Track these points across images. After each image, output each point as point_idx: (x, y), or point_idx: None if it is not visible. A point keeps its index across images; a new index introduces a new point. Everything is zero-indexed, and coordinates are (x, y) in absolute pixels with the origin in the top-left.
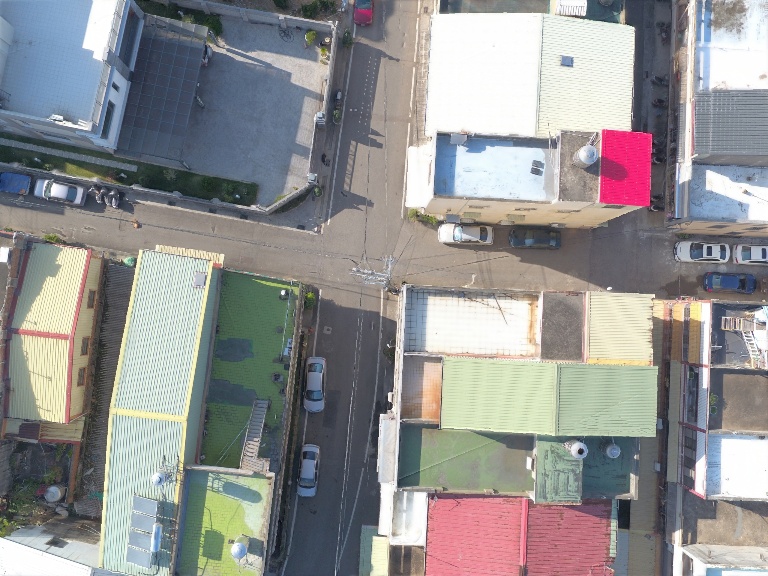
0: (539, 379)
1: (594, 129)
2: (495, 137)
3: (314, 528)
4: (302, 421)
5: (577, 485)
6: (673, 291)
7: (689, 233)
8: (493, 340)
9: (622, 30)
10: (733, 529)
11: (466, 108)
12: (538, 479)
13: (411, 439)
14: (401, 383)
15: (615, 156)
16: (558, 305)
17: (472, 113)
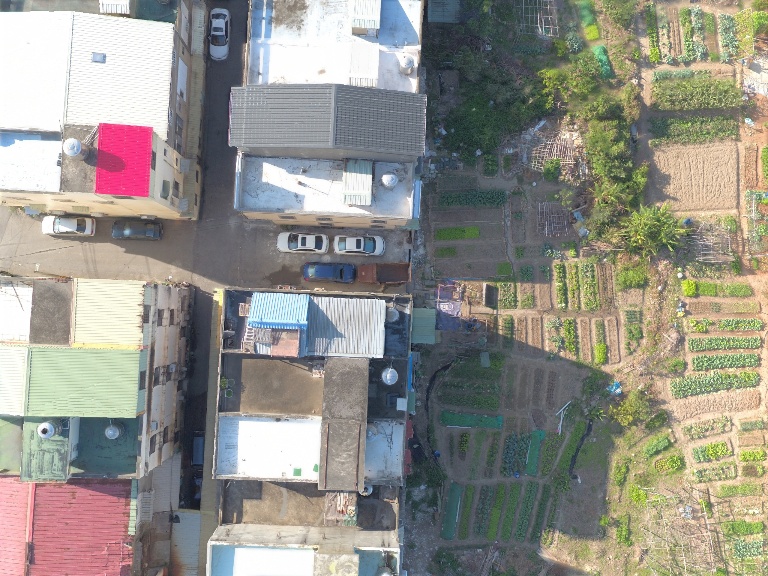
0: (13, 362)
1: (128, 123)
2: (18, 131)
3: None
4: None
5: (62, 464)
6: (277, 281)
7: (291, 224)
8: (9, 326)
9: (159, 27)
10: (278, 509)
11: (1, 103)
12: (24, 458)
13: None
14: None
15: (112, 149)
16: (47, 292)
17: (7, 108)
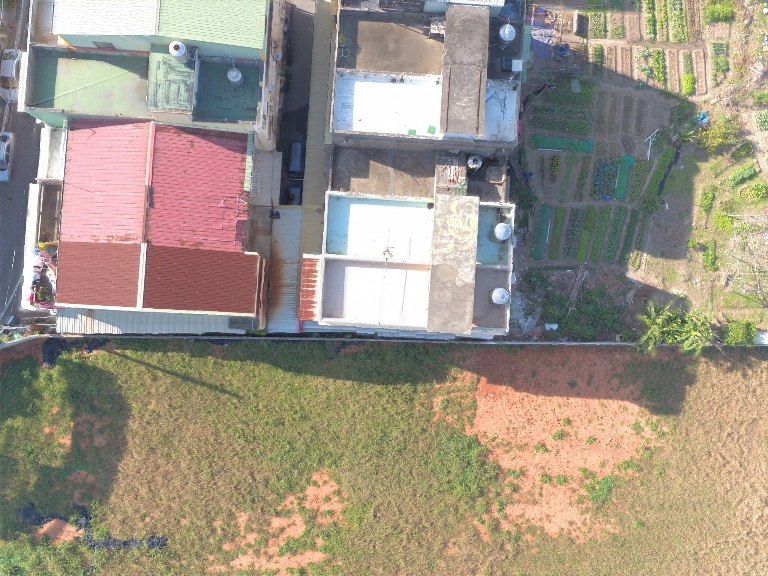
0: None
1: None
2: None
3: (9, 213)
4: (1, 112)
5: (188, 95)
6: None
7: None
8: None
9: None
10: (385, 188)
11: None
12: (150, 88)
13: (46, 68)
14: (31, 7)
15: None
16: None
17: None
